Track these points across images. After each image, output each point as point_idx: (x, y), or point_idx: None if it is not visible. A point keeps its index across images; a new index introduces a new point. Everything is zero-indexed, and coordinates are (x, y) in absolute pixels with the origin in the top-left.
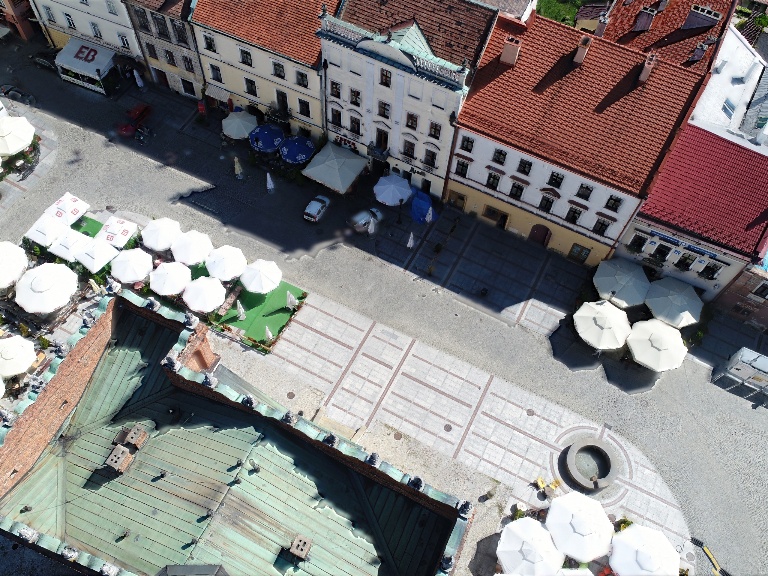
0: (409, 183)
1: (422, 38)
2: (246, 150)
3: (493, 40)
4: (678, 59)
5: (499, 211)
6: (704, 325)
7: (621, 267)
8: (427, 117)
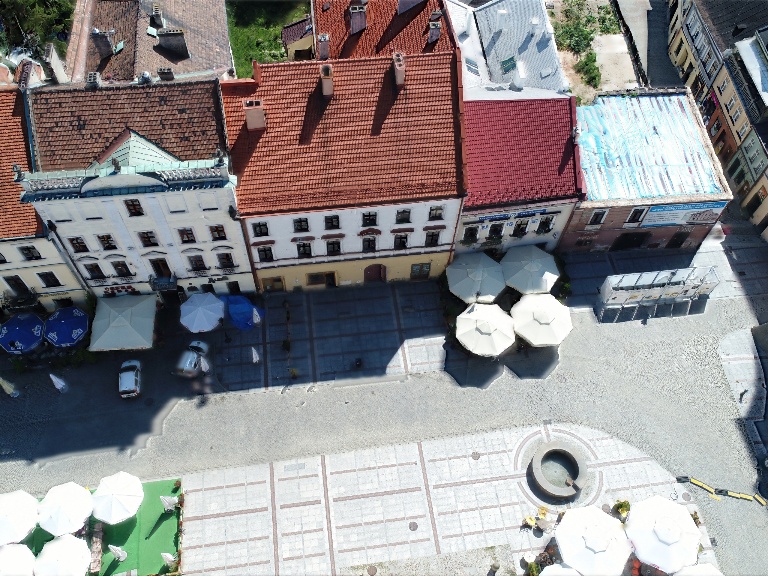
0: (213, 294)
1: (149, 145)
2: (3, 358)
3: (228, 112)
4: (416, 46)
5: (323, 273)
6: (565, 275)
7: (467, 264)
8: (202, 224)
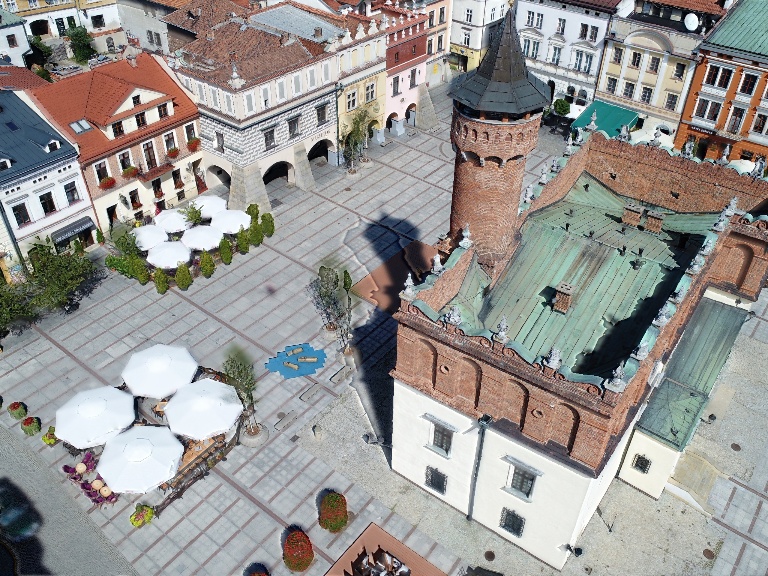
0: None
1: None
2: None
3: None
4: None
5: None
6: None
7: None
8: None
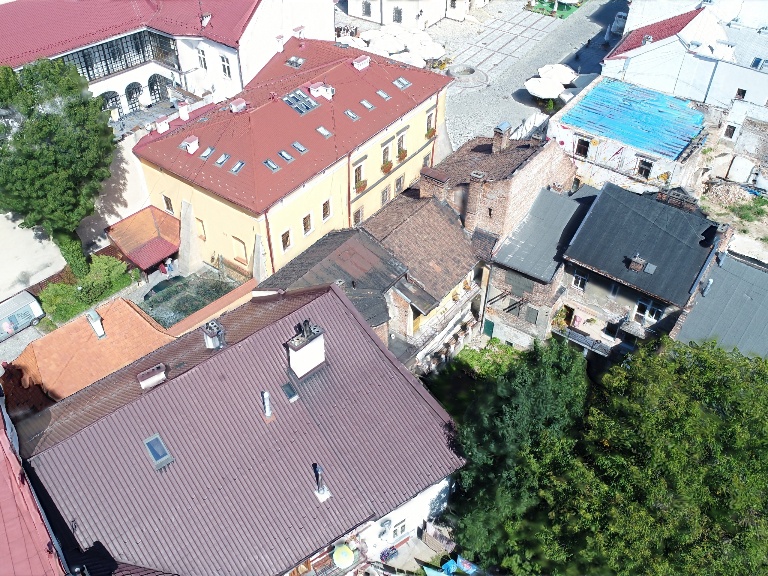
0: None
1: None
2: None
3: None
4: None
5: None
6: None
7: None
8: None
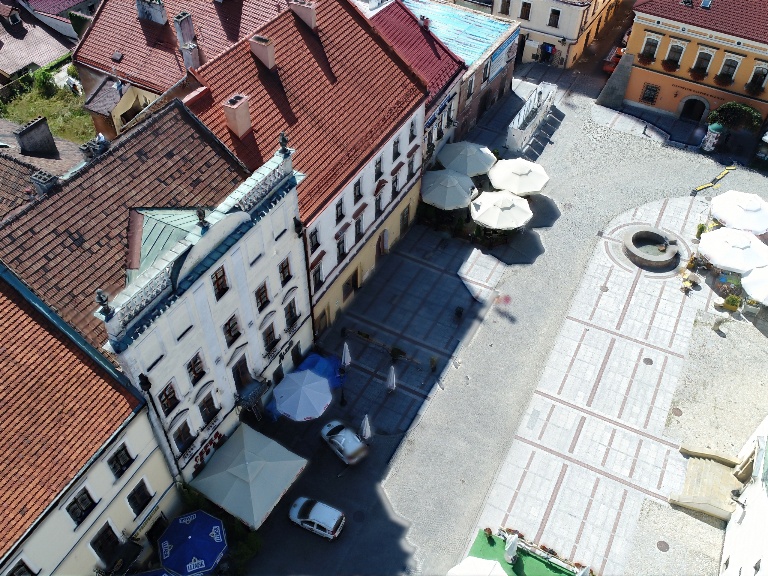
0: None
1: (168, 213)
2: None
3: None
4: (276, 7)
5: (351, 276)
6: None
7: (435, 182)
8: (275, 266)
